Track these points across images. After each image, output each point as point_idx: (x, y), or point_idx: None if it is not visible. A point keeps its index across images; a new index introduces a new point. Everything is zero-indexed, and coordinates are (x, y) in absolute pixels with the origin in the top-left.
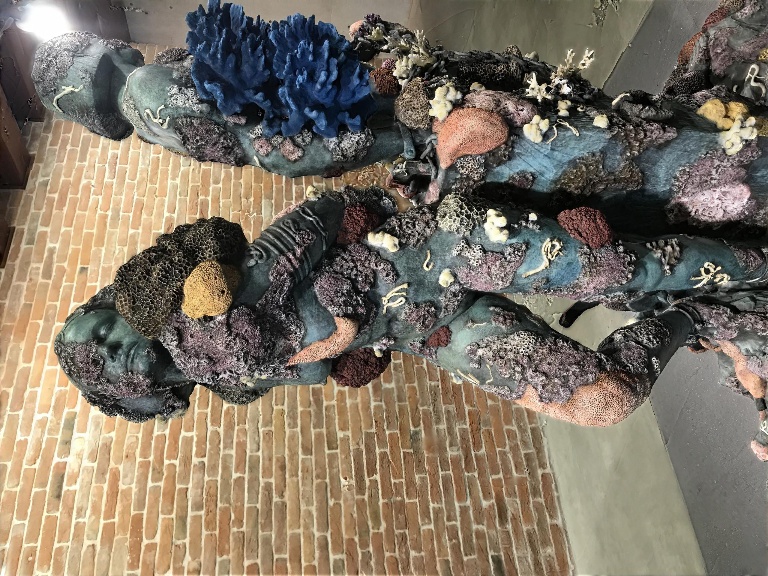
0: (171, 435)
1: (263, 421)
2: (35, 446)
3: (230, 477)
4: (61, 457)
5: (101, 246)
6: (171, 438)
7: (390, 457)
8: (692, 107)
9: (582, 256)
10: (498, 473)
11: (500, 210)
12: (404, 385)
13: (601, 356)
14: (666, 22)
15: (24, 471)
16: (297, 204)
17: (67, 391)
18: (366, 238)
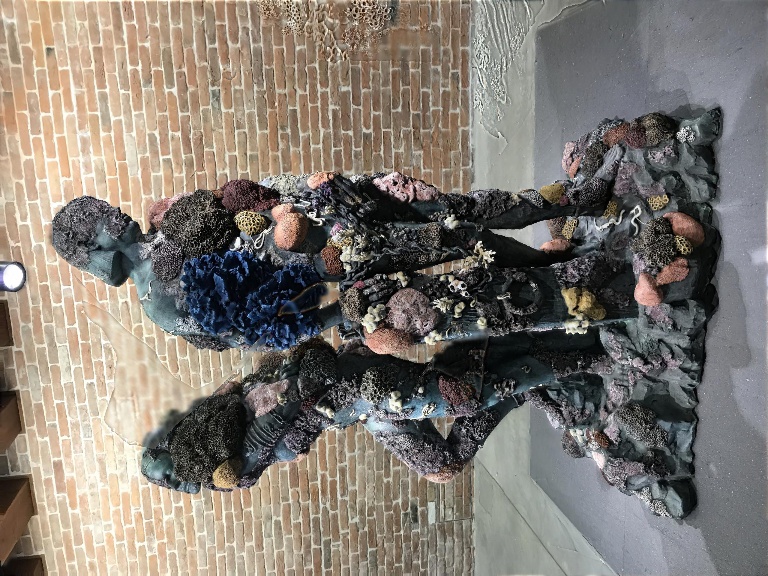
0: None
1: None
2: None
3: None
4: None
5: (60, 21)
6: None
7: None
8: (560, 284)
9: (446, 412)
10: None
11: (401, 384)
12: (362, 172)
13: (447, 454)
14: (632, 24)
15: None
16: (272, 407)
17: (71, 181)
18: (315, 405)
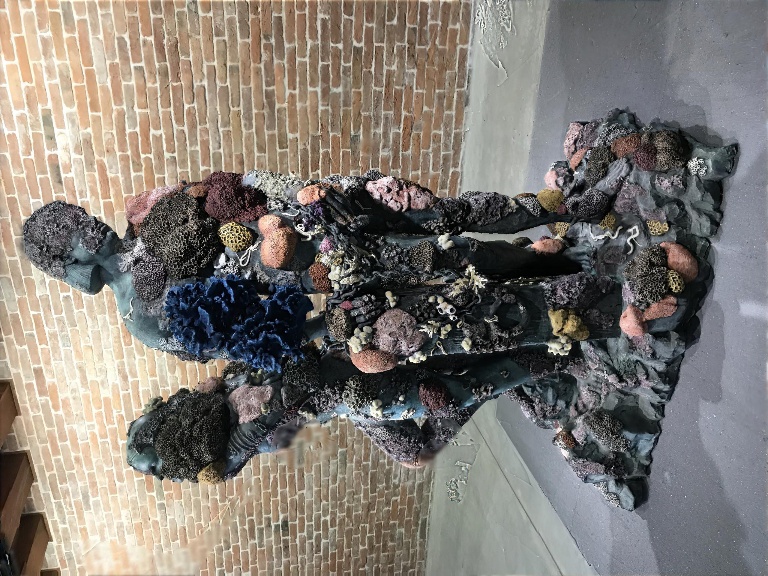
0: (142, 132)
1: (222, 121)
2: (25, 141)
3: (198, 170)
4: (51, 150)
5: None
6: (142, 134)
7: (331, 156)
8: (548, 305)
9: (425, 416)
10: (418, 169)
11: (383, 393)
12: (350, 90)
13: (421, 446)
14: (660, 12)
15: (24, 163)
16: (255, 416)
17: (34, 87)
18: None
